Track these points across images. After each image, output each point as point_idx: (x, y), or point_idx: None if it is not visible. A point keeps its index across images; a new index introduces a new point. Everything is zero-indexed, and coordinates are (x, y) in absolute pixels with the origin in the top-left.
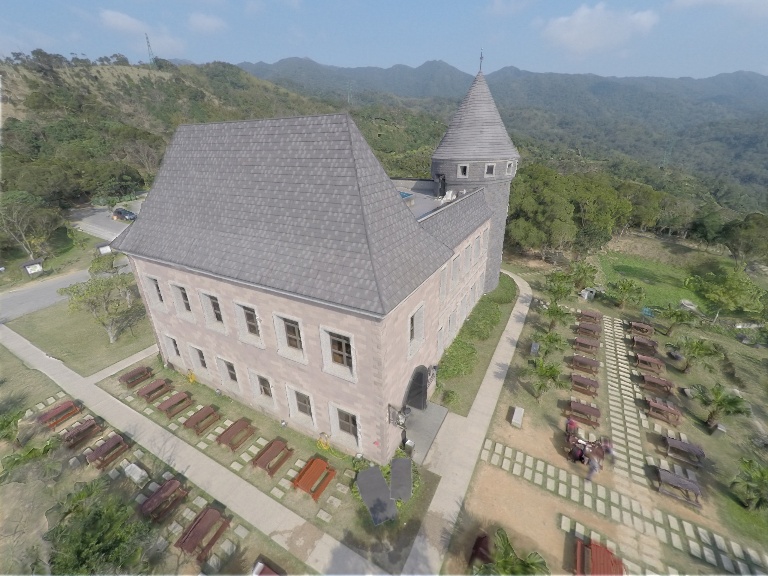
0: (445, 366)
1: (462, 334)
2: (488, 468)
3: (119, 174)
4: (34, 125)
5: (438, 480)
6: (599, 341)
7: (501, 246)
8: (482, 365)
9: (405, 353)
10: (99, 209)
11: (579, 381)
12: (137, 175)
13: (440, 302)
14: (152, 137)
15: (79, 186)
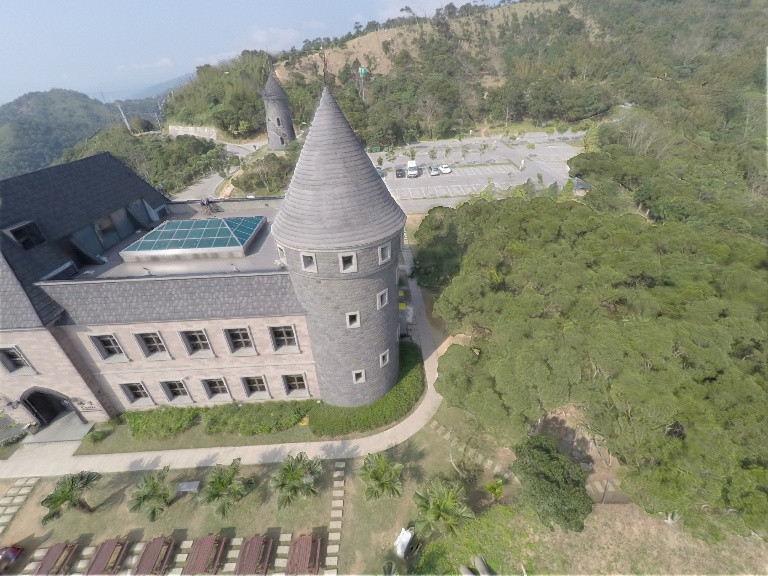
0: (142, 415)
1: (210, 410)
2: (7, 488)
3: (386, 128)
4: (384, 80)
5: (5, 458)
6: None
7: (343, 361)
8: (156, 445)
9: (2, 368)
10: None
11: (103, 547)
12: (404, 129)
13: (113, 360)
14: (449, 90)
15: (362, 135)
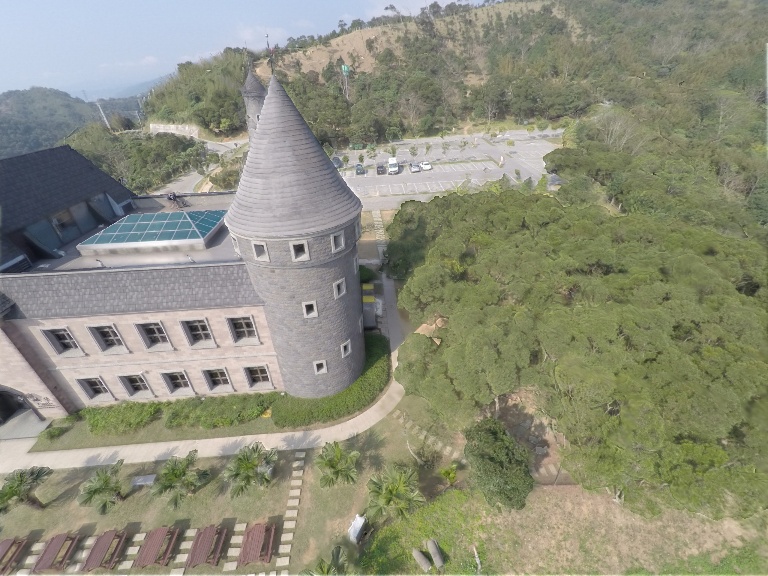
0: (102, 411)
1: (172, 404)
2: None
3: (368, 126)
4: (367, 78)
5: None
6: (185, 568)
7: (303, 352)
8: (115, 440)
9: None
10: (342, 153)
11: (52, 542)
12: (386, 127)
13: (68, 354)
14: (431, 88)
15: (344, 133)
